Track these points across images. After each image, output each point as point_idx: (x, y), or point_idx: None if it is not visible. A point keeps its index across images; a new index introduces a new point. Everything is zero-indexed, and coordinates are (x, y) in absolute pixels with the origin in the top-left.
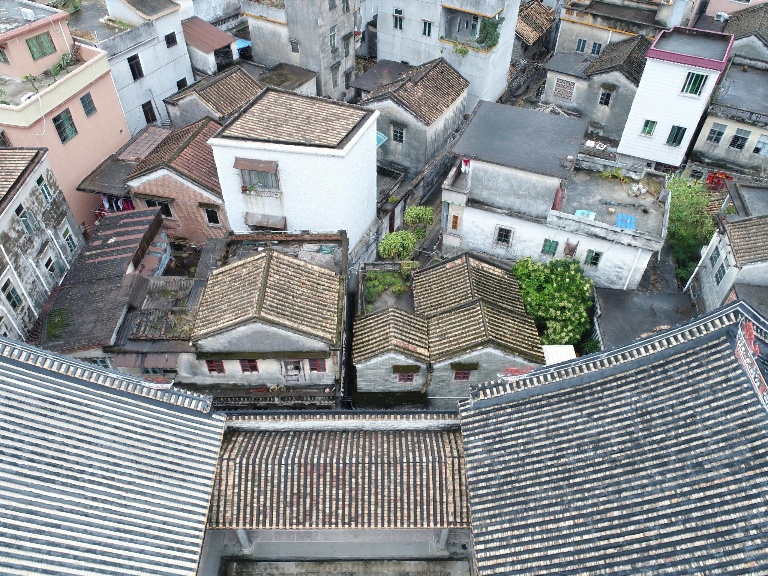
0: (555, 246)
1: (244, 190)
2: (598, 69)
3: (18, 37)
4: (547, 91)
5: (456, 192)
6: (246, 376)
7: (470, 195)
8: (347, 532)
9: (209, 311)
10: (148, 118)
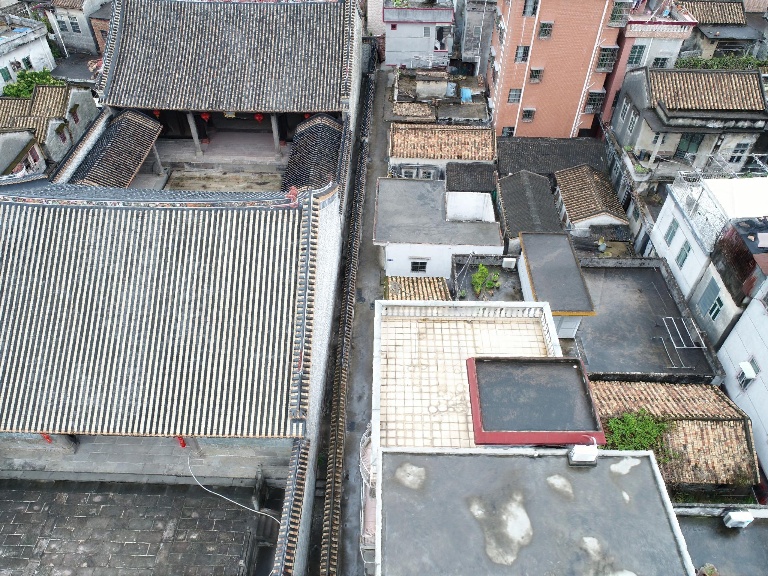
0: (7, 71)
1: None
2: None
3: None
4: None
5: None
6: None
7: None
8: None
9: None
10: None
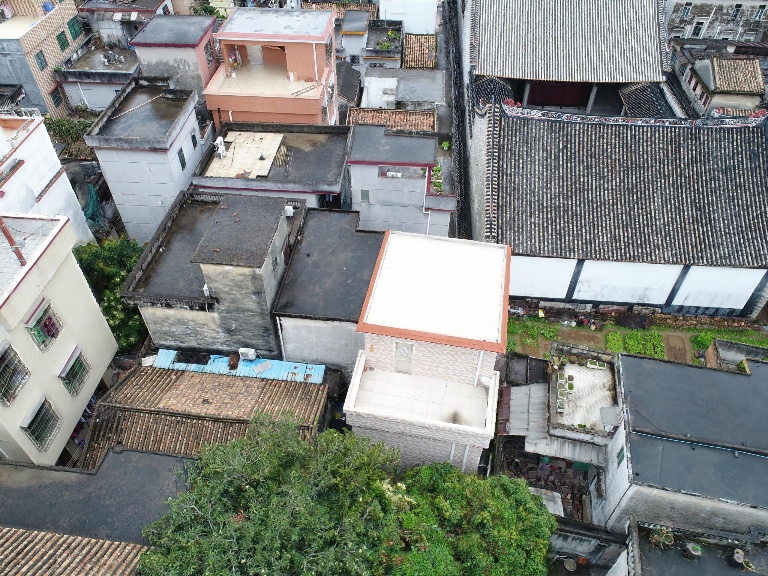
0: None
1: None
2: None
3: None
4: None
5: None
6: None
7: None
8: None
9: None
10: None
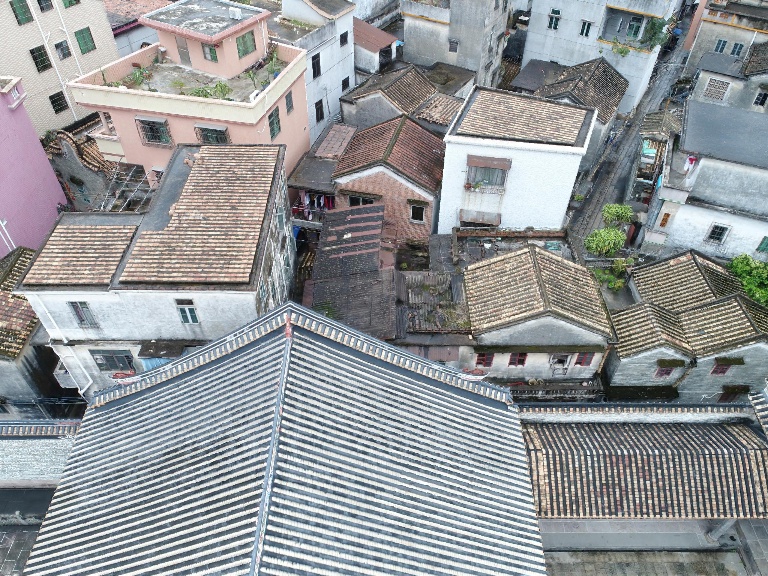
0: None
1: (469, 187)
2: (757, 69)
3: (231, 35)
4: (697, 91)
5: (678, 190)
6: (509, 369)
7: (691, 193)
8: (613, 523)
9: (482, 305)
10: (318, 116)
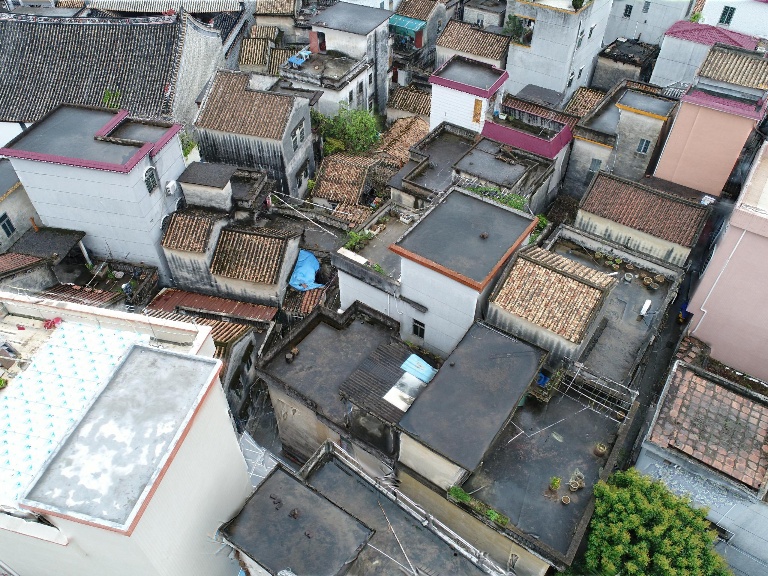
0: None
1: None
2: None
3: None
4: None
5: None
6: None
7: None
8: None
9: None
10: None
